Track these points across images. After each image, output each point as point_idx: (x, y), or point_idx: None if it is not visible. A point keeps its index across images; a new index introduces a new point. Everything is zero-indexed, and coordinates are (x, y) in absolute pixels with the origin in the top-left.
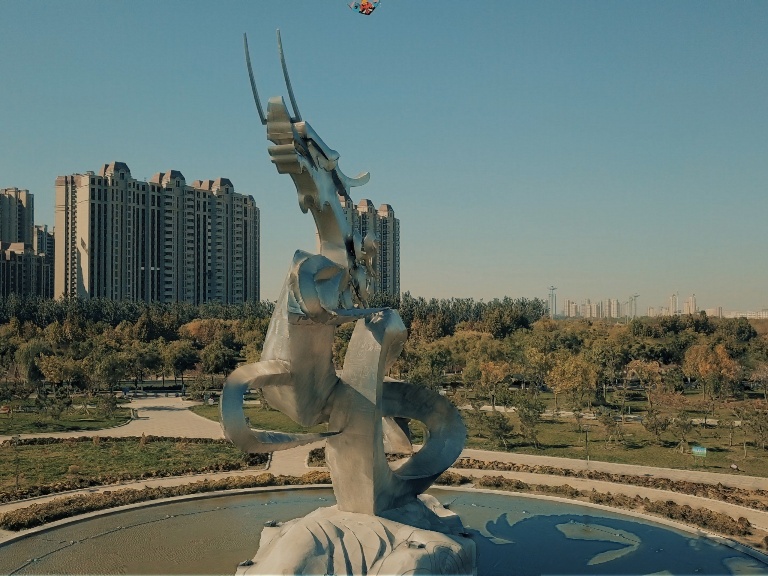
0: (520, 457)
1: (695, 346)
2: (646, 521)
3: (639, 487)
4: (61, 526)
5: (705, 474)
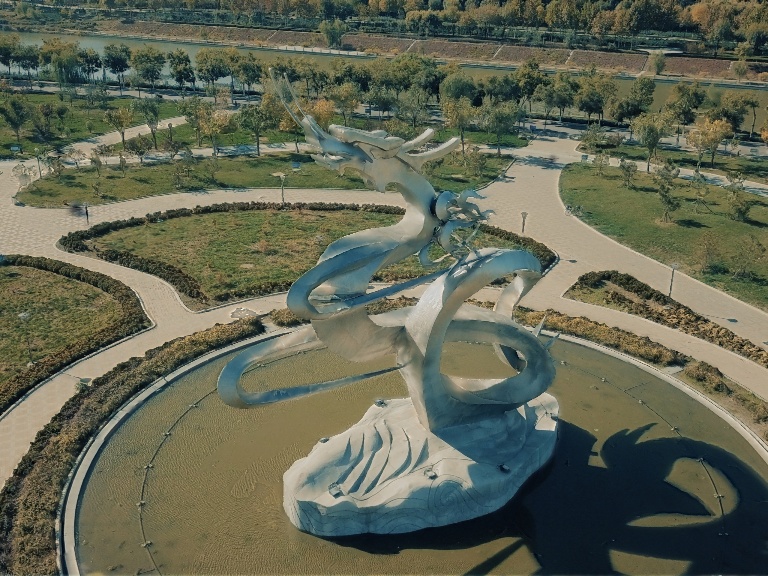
0: None
1: None
2: None
3: None
4: None
5: None
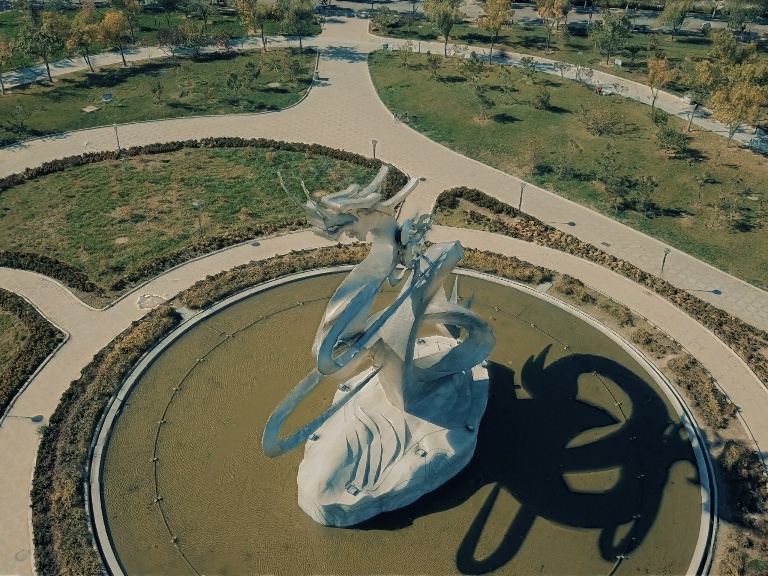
0: (621, 232)
1: None
2: (655, 384)
3: (690, 318)
4: (224, 308)
5: None
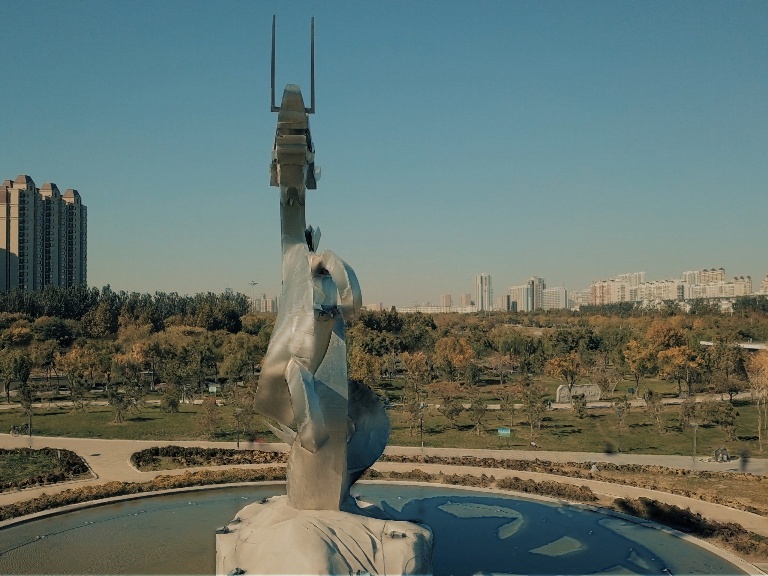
0: None
1: (444, 339)
2: (508, 496)
3: (474, 467)
4: None
5: (513, 452)
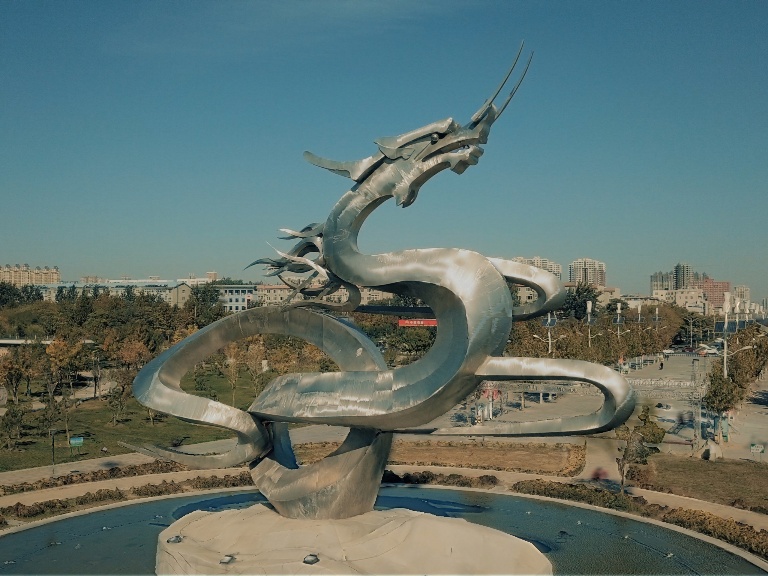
0: None
1: None
2: (233, 493)
3: (121, 479)
4: None
5: (99, 460)
